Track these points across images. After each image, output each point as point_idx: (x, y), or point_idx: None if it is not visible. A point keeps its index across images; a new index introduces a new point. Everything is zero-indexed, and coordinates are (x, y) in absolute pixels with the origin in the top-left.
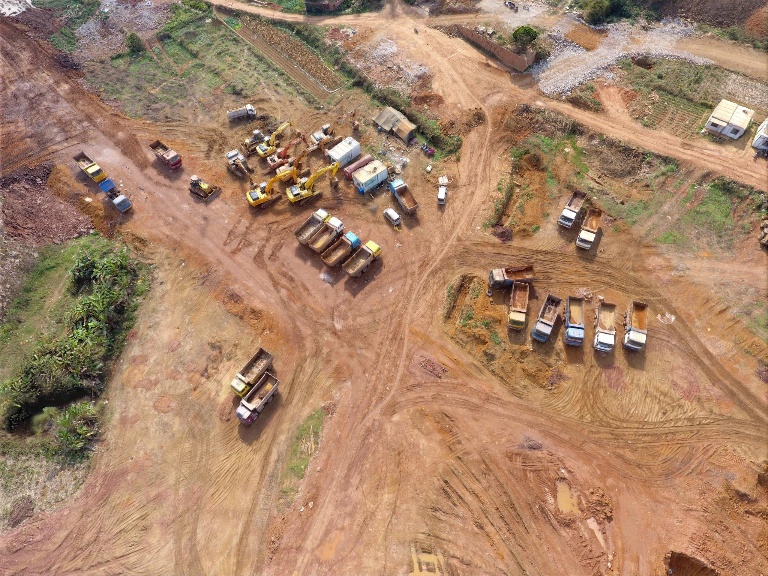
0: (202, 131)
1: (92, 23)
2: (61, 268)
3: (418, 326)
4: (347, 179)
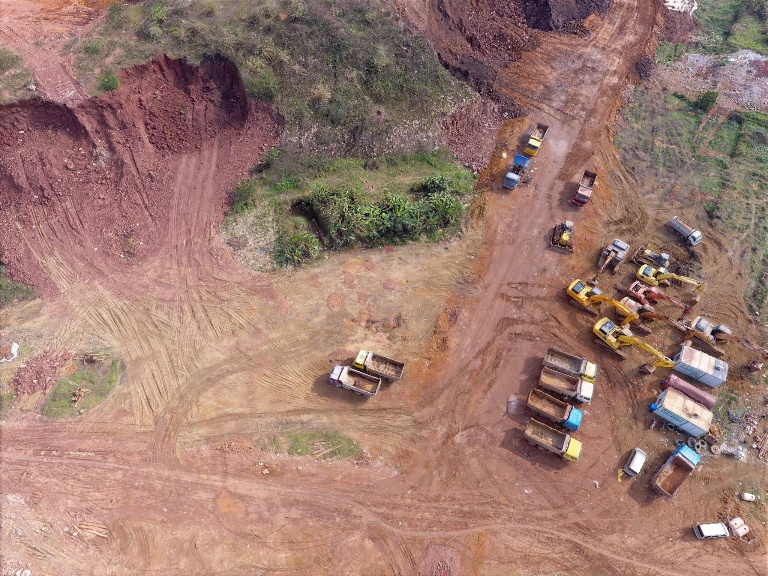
0: (636, 205)
1: (707, 59)
2: (433, 170)
3: (491, 544)
4: (662, 383)
